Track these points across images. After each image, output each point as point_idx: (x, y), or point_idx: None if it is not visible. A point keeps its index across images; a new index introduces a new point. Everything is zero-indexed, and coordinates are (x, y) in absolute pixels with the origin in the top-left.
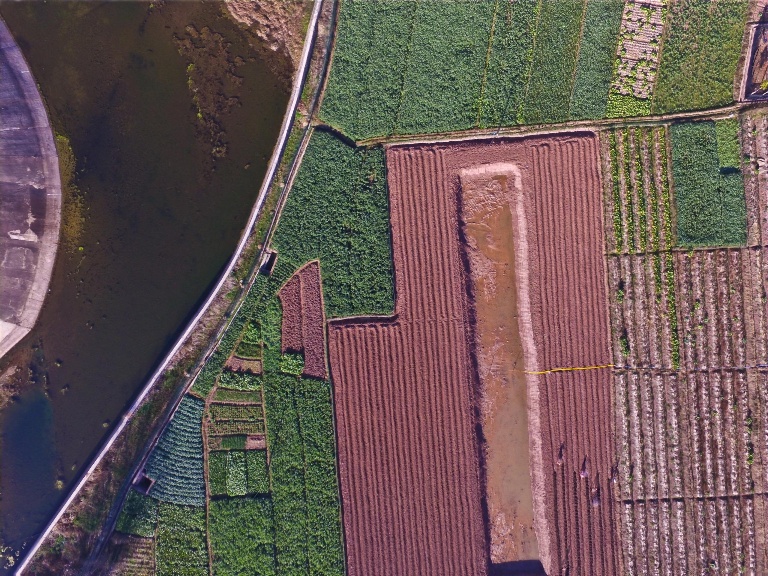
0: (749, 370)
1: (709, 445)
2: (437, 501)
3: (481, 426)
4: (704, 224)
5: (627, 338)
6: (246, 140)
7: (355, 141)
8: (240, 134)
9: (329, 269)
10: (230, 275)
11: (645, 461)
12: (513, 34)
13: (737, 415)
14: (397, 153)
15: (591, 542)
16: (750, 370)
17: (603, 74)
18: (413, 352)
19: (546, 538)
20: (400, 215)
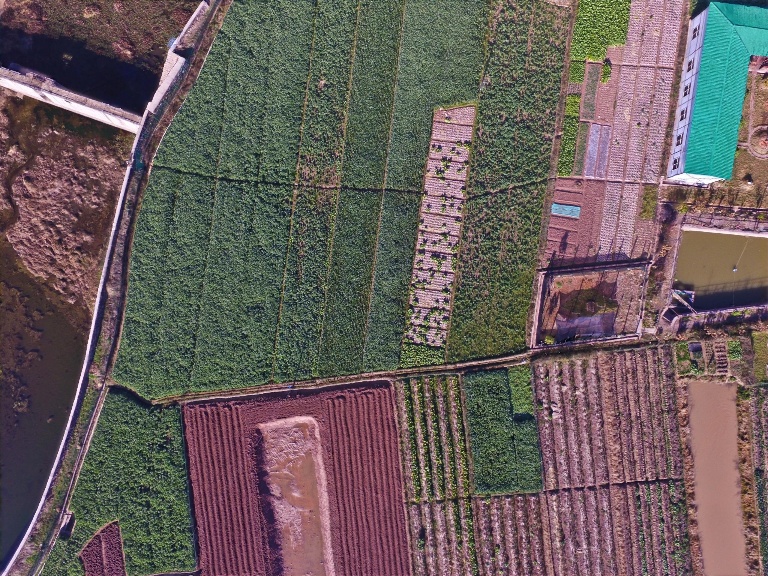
0: None
1: None
2: None
3: None
4: (500, 472)
5: None
6: (48, 393)
7: (150, 400)
8: (42, 387)
9: (128, 530)
10: (28, 542)
11: None
12: (304, 289)
13: None
14: (193, 410)
15: None
16: None
17: (394, 326)
18: None
19: None
20: (198, 472)
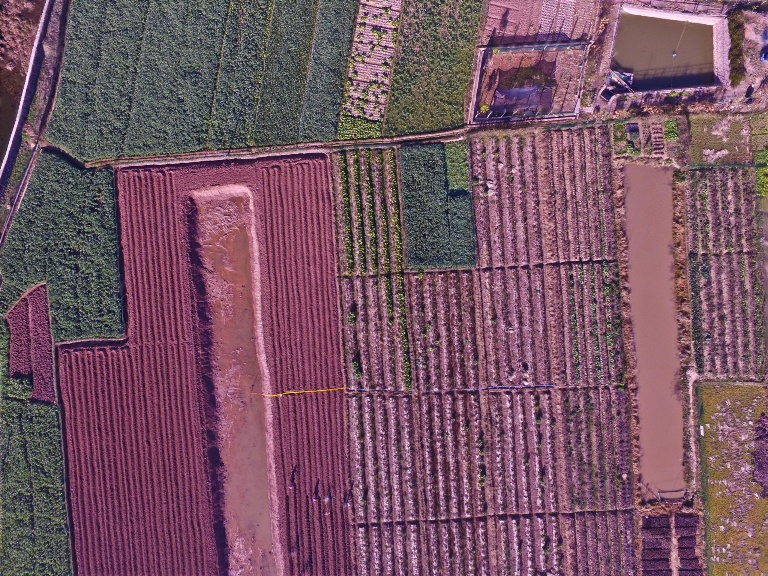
0: (481, 392)
1: (441, 467)
2: (168, 527)
3: (218, 450)
4: (433, 246)
5: (360, 360)
6: None
7: (84, 162)
8: None
9: (56, 292)
10: None
11: (379, 484)
12: (242, 56)
13: (470, 437)
14: (126, 175)
15: (324, 566)
16: (482, 392)
17: (332, 96)
18: (142, 376)
19: (281, 563)
20: (129, 237)
